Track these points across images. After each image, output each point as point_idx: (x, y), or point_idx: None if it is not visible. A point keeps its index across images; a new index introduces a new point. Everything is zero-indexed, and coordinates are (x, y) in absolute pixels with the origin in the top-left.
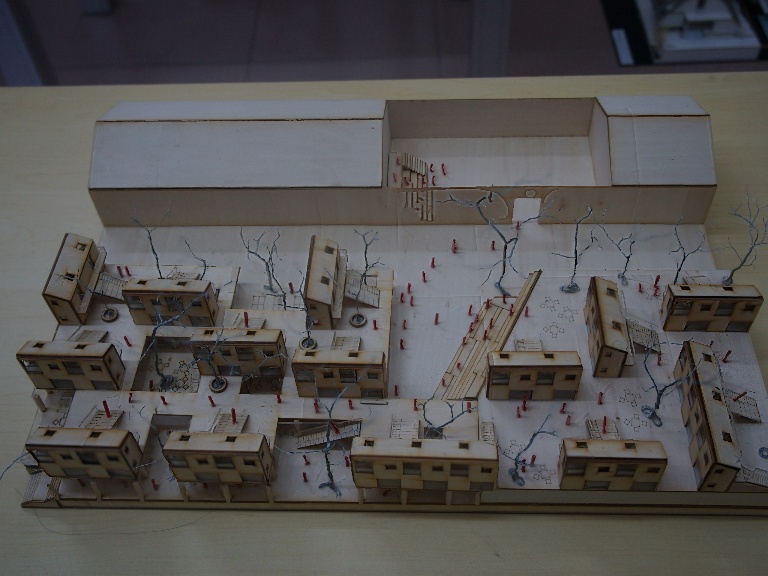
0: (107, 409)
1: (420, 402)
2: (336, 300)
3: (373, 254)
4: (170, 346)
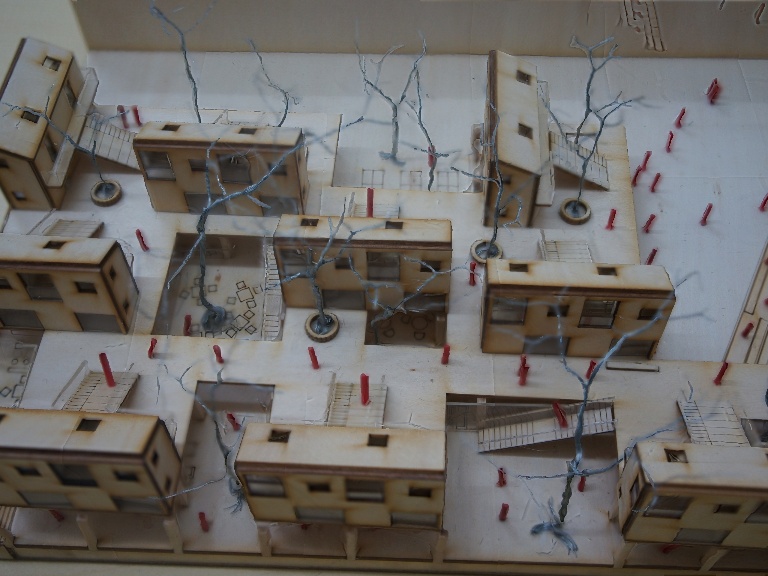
0: (108, 370)
1: None
2: None
3: (567, 103)
4: (217, 254)
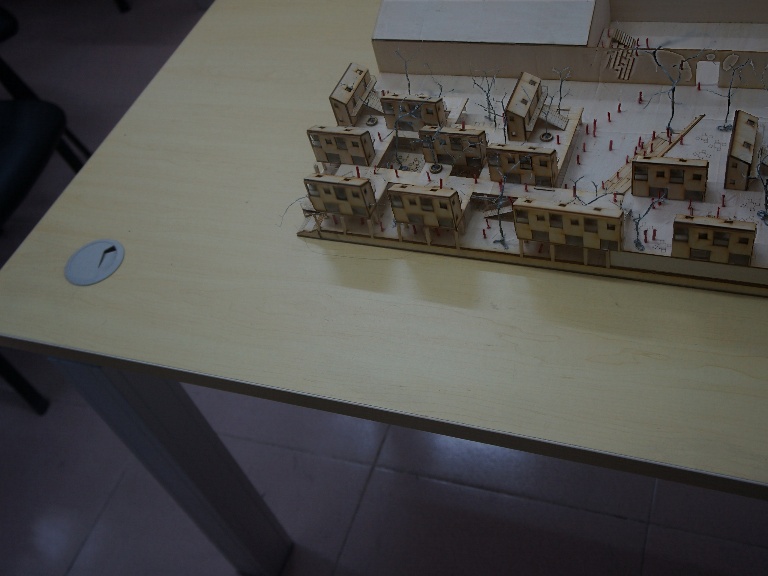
0: (358, 173)
1: (579, 192)
2: (532, 119)
3: (574, 101)
4: (410, 148)
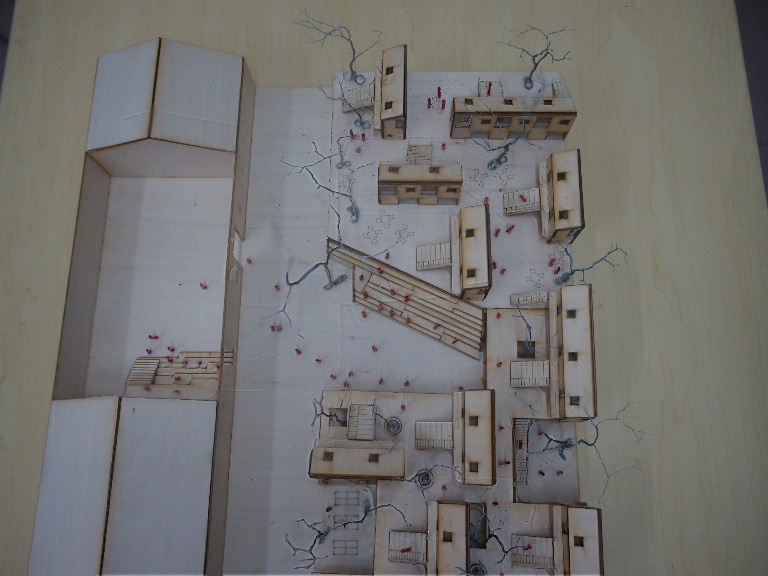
0: None
1: (490, 362)
2: None
3: (277, 419)
4: None
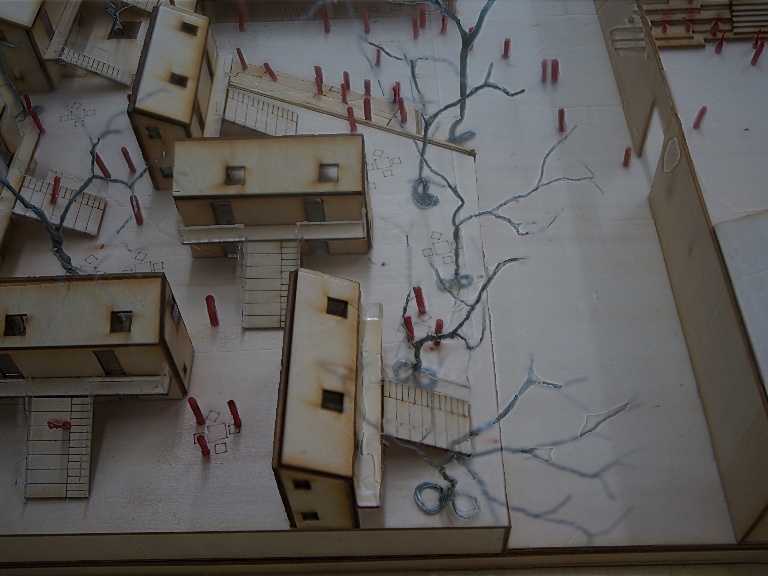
0: None
1: None
2: None
3: None
4: None
